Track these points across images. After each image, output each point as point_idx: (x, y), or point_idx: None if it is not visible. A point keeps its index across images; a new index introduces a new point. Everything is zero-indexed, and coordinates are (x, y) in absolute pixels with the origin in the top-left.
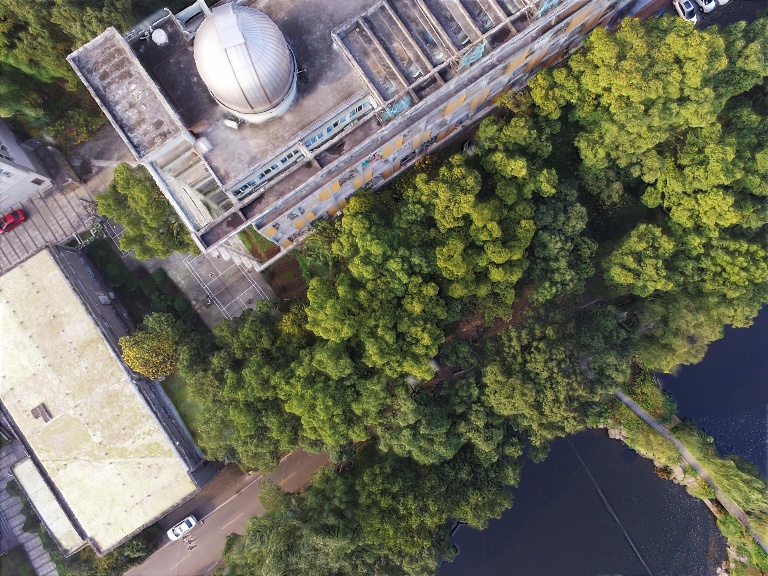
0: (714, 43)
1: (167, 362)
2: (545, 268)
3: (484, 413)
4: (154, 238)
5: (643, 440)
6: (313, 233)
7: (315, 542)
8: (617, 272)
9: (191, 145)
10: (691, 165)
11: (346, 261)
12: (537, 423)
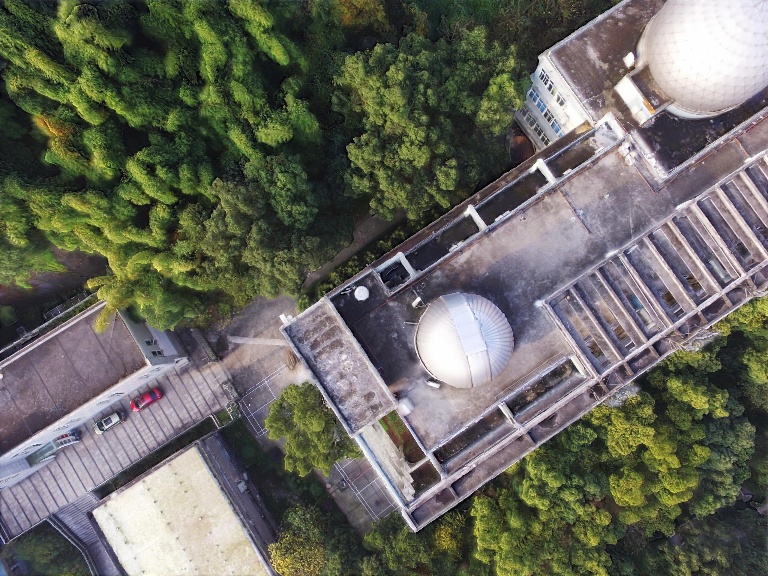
0: None
1: (316, 569)
2: None
3: None
4: (323, 462)
5: None
6: None
7: None
8: None
9: None
10: None
11: (509, 478)
12: None
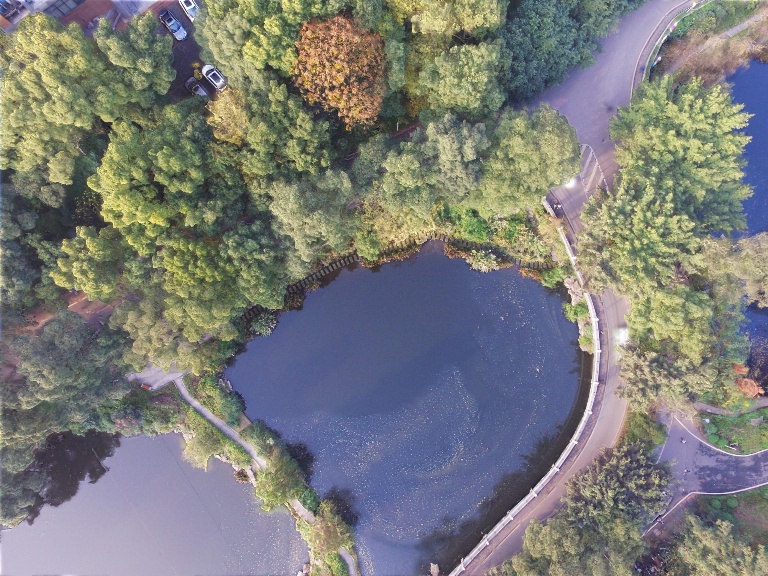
0: (61, 41)
1: None
2: None
3: None
4: None
5: None
6: None
7: None
8: None
9: None
10: None
11: None
12: None
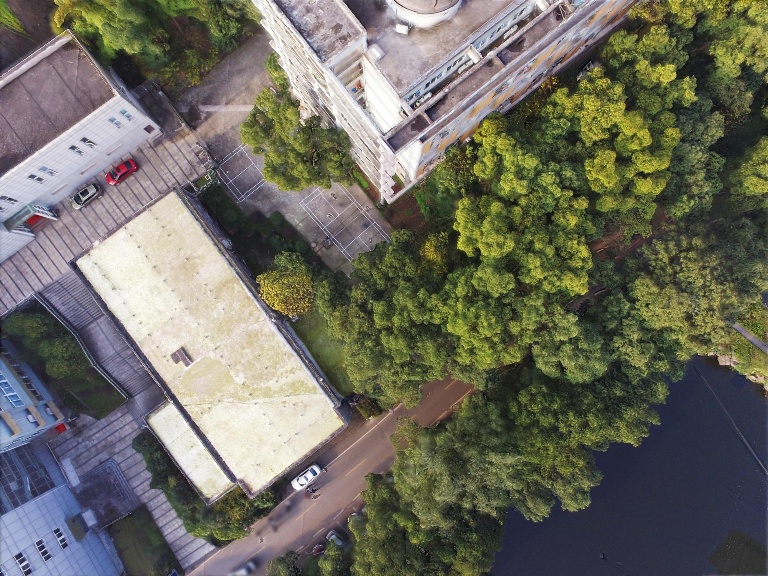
0: None
1: (306, 298)
2: (678, 183)
3: (636, 326)
4: (302, 165)
5: (759, 362)
6: (443, 161)
7: (482, 462)
8: (754, 181)
9: (362, 53)
10: None
11: (488, 182)
12: (686, 335)
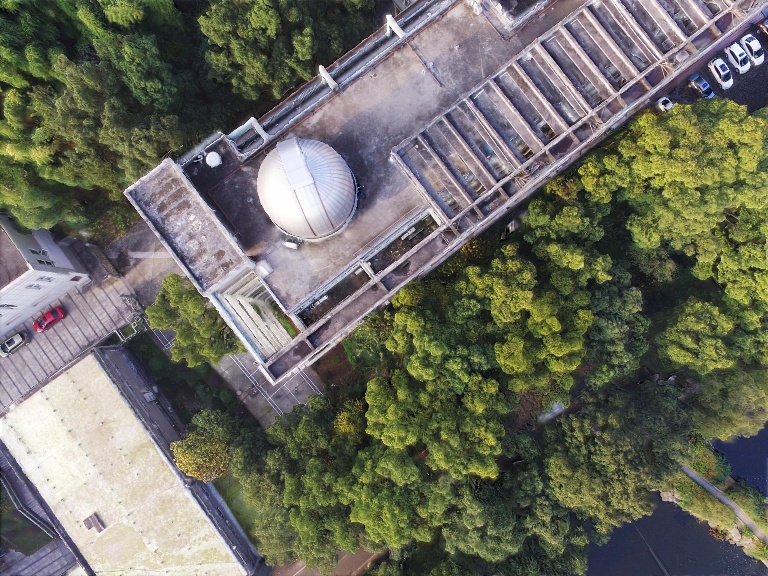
0: None
1: (220, 464)
2: (600, 349)
3: (550, 507)
4: (207, 348)
5: (699, 505)
6: (362, 324)
7: None
8: (675, 352)
9: (251, 268)
10: (746, 243)
11: (400, 357)
12: (603, 513)
